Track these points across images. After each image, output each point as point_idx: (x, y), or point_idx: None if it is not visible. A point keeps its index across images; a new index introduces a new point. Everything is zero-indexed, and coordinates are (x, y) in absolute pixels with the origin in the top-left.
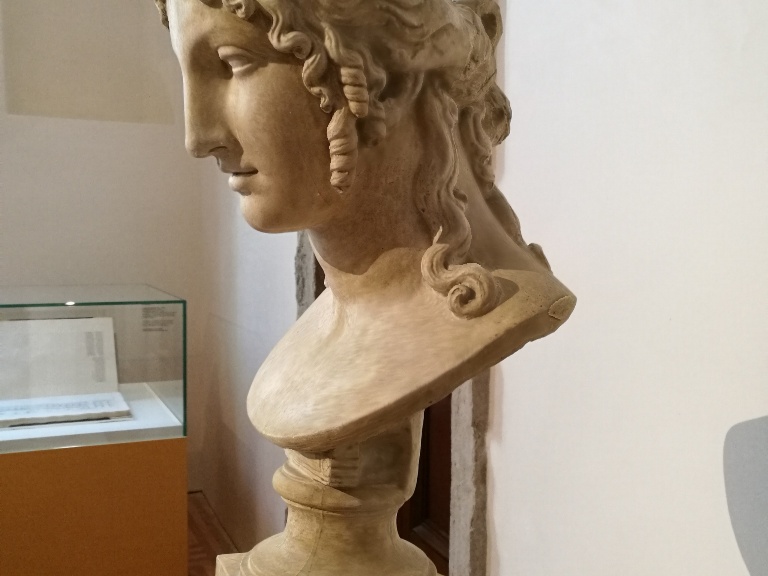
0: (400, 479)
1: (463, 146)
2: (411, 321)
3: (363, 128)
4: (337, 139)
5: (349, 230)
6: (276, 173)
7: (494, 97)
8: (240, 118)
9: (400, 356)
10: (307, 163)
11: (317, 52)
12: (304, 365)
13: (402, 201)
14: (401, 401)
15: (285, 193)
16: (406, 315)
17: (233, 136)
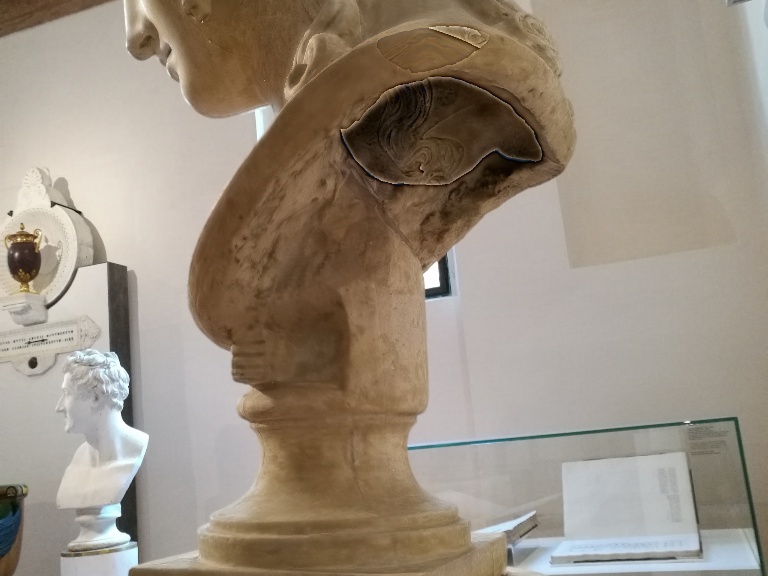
0: (341, 376)
1: None
2: None
3: None
4: None
5: (265, 76)
6: (169, 35)
7: None
8: None
9: None
10: (181, 8)
11: None
12: None
13: (292, 13)
14: (208, 223)
15: (184, 54)
16: None
17: (148, 20)
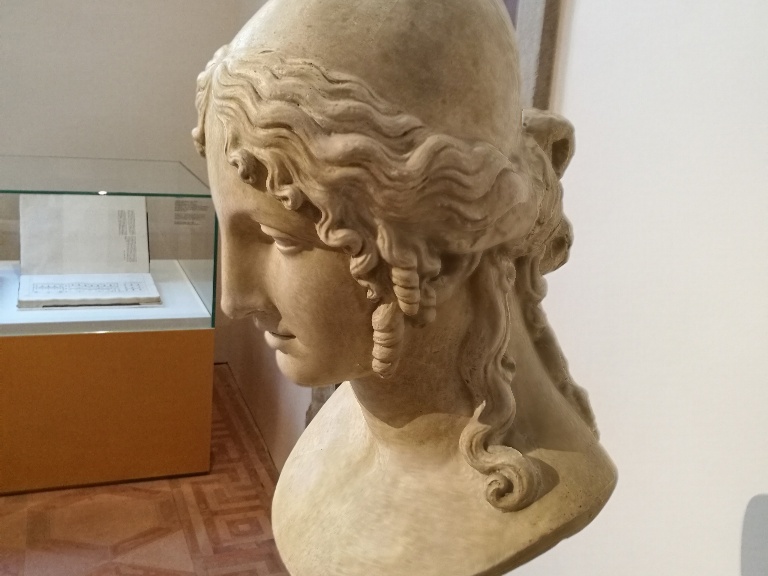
0: None
1: (517, 294)
2: (444, 491)
3: None
4: (382, 332)
5: (388, 389)
6: (315, 346)
7: None
8: (280, 291)
9: (429, 535)
10: (348, 341)
11: (368, 252)
12: (331, 493)
13: (446, 369)
14: None
15: (323, 363)
16: (439, 481)
17: (271, 303)
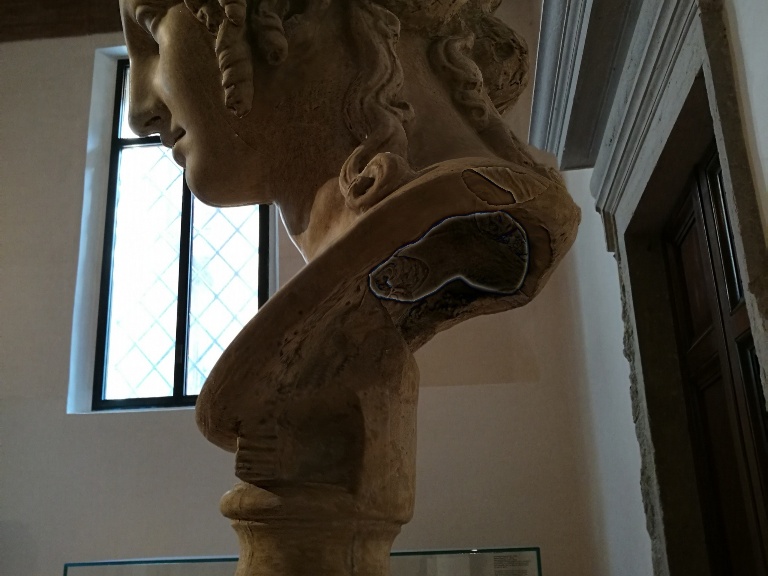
0: (351, 479)
1: (434, 73)
2: None
3: (258, 43)
4: (220, 54)
5: (286, 177)
6: (191, 122)
7: (496, 32)
8: (159, 78)
9: None
10: (213, 99)
11: None
12: None
13: (330, 125)
14: (261, 314)
15: (204, 142)
16: None
17: (162, 102)
